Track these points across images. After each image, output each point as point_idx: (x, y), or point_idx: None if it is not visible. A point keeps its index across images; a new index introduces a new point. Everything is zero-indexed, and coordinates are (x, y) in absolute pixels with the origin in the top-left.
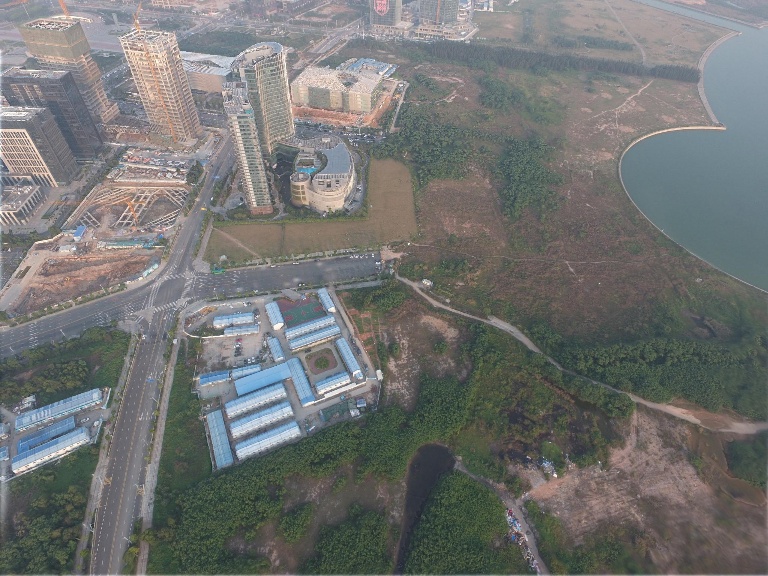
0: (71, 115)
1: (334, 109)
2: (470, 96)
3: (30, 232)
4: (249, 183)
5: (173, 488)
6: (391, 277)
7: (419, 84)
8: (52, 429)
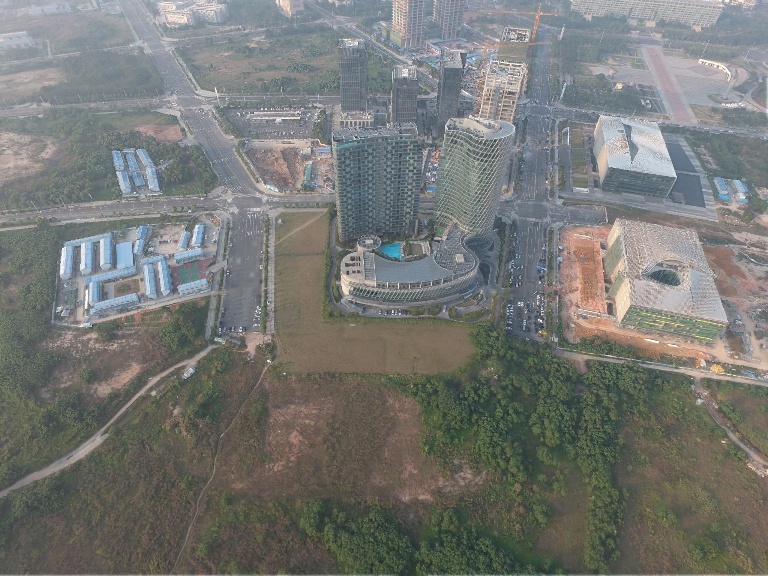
0: None
1: (612, 283)
2: None
3: None
4: None
5: (69, 229)
6: (211, 339)
7: None
8: (139, 179)
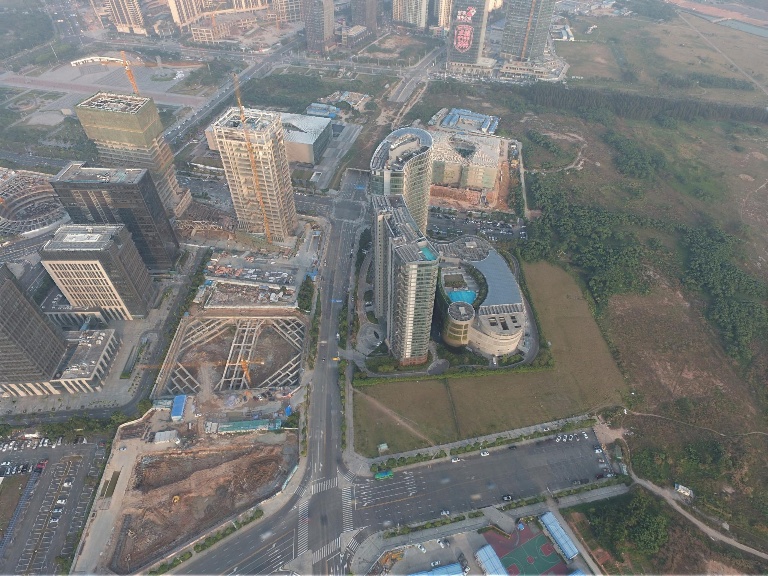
0: (147, 223)
1: (446, 183)
2: (601, 160)
3: (112, 412)
4: (408, 334)
5: None
6: (629, 481)
7: (535, 145)
8: None
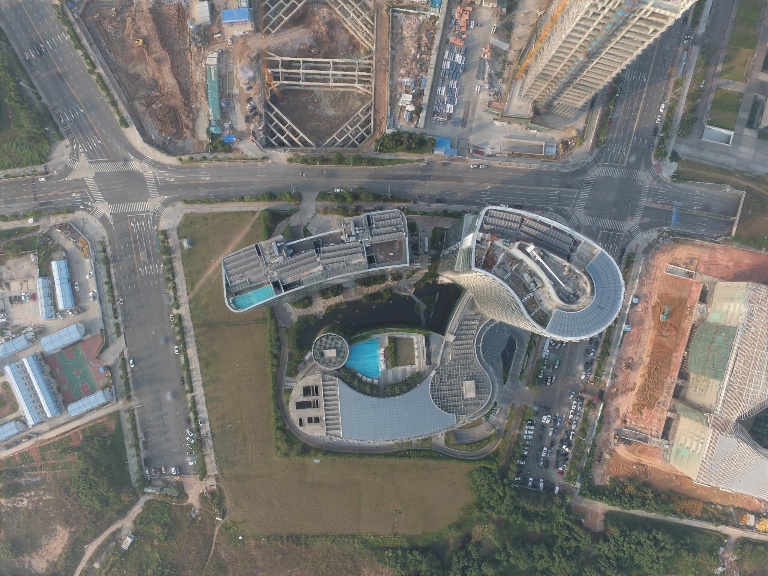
0: None
1: (689, 378)
2: None
3: None
4: None
5: None
6: None
7: None
8: None
